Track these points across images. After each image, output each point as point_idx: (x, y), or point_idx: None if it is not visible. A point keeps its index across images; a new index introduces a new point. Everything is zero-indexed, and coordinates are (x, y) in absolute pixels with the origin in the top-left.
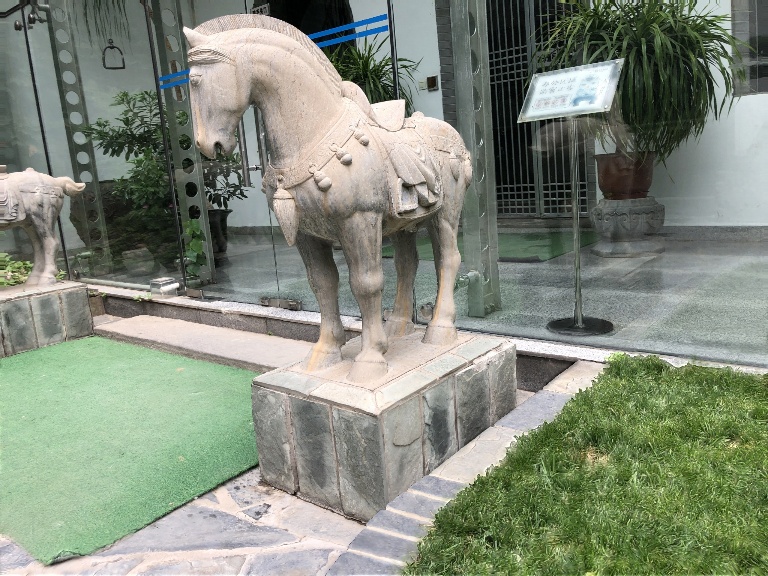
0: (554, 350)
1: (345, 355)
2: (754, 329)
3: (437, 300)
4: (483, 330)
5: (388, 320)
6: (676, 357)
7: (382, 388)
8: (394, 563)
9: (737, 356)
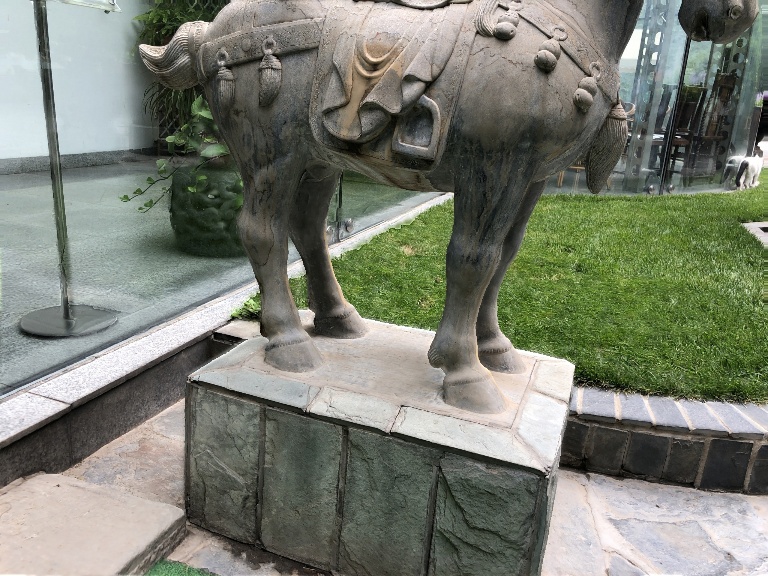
0: (171, 340)
1: (429, 383)
2: (144, 266)
3: (333, 277)
4: (15, 382)
5: (304, 340)
6: (221, 297)
7: (526, 356)
8: (681, 406)
9: (229, 280)
